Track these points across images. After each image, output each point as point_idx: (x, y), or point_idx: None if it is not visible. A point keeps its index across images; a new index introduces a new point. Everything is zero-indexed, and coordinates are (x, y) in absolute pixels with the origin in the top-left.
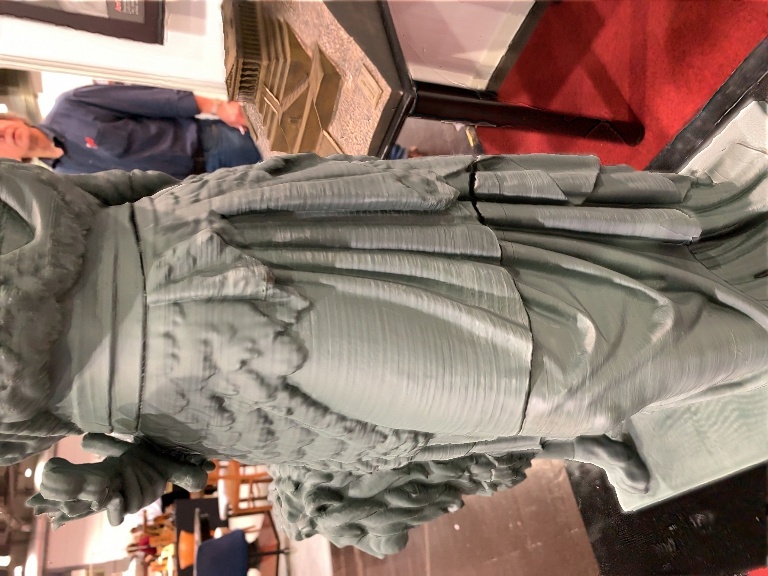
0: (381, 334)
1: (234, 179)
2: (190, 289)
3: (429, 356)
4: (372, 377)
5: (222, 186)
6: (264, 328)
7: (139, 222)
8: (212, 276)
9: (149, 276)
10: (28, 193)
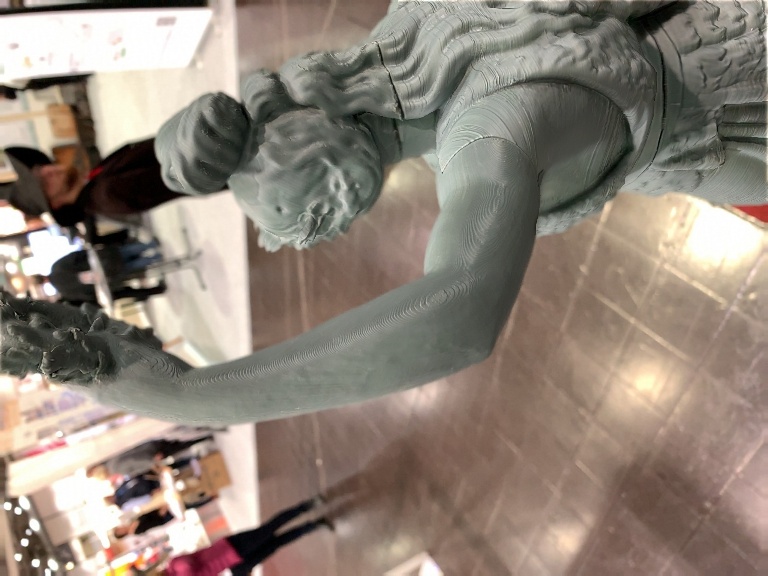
0: (739, 180)
1: (750, 67)
2: (681, 168)
3: (748, 190)
4: (713, 195)
5: (740, 75)
6: (693, 182)
7: (669, 93)
8: (696, 160)
9: (662, 153)
10: (646, 115)
